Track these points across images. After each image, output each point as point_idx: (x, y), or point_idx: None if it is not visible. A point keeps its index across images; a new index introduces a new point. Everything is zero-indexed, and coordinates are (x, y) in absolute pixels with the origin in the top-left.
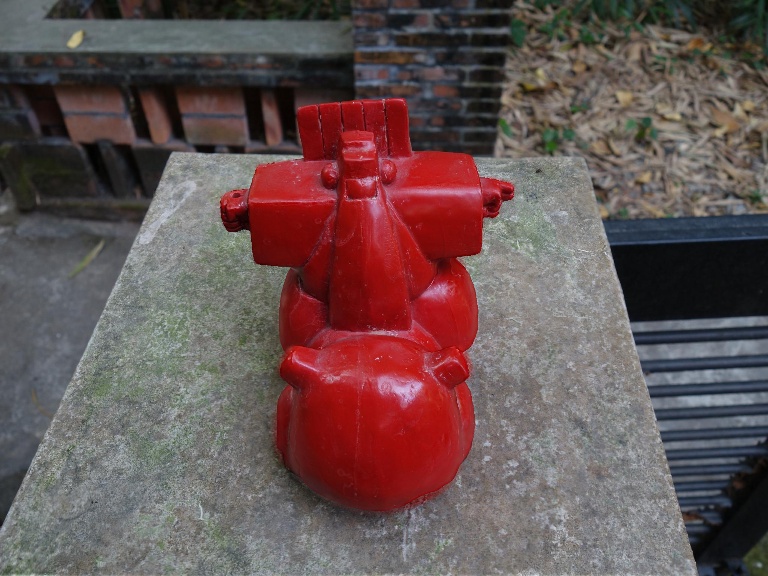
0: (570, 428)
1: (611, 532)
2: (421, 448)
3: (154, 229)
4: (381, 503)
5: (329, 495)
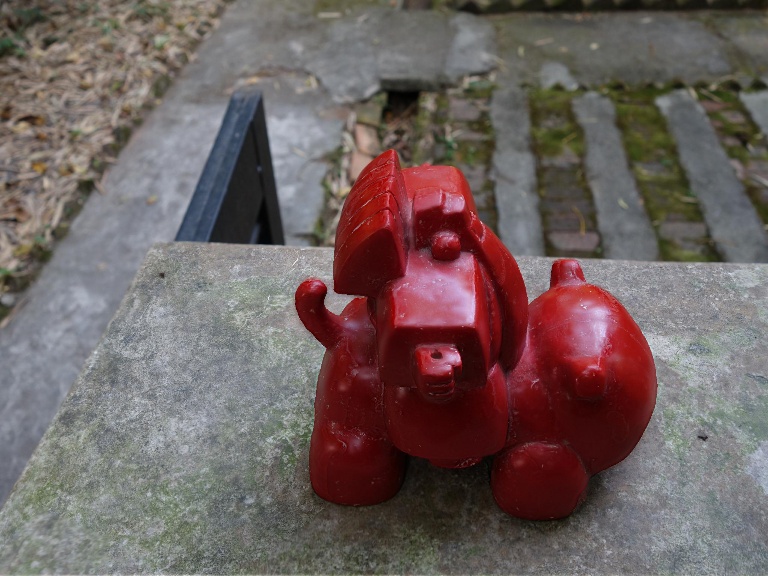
0: None
1: None
2: None
3: None
4: None
5: None
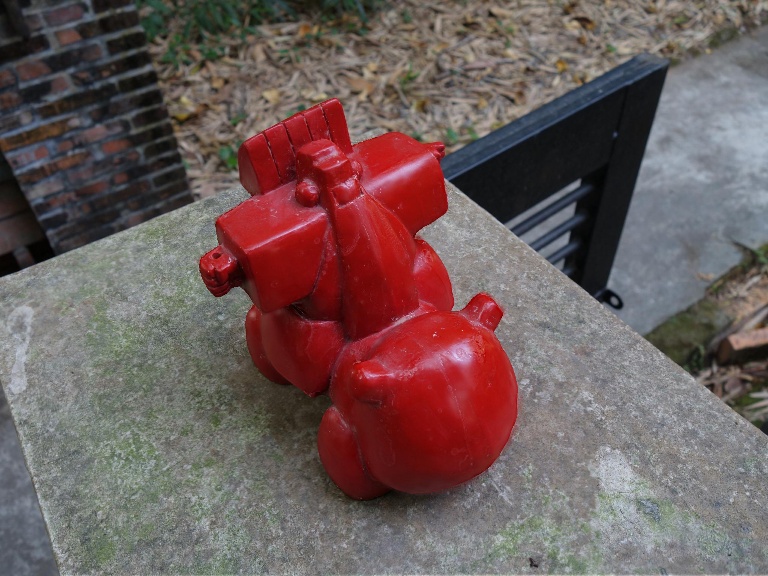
0: (541, 332)
1: (626, 387)
2: (505, 391)
3: (20, 372)
4: (489, 461)
5: (442, 483)
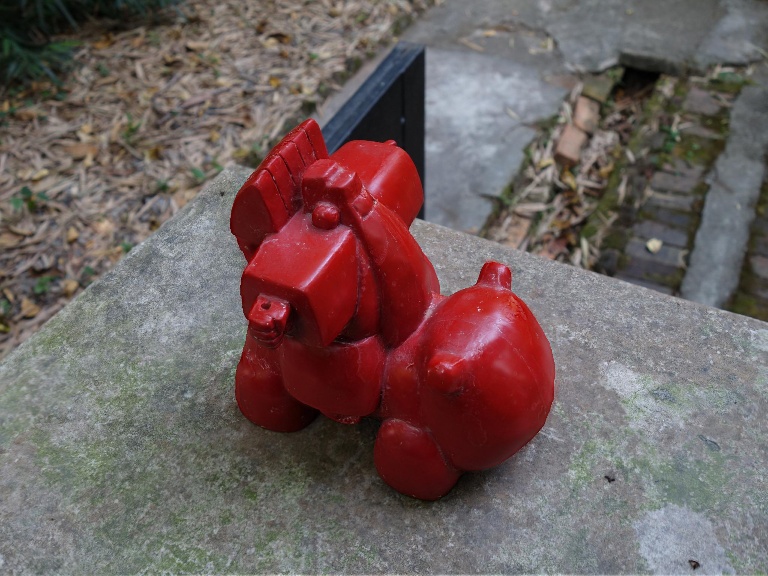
0: None
1: (586, 310)
2: (545, 338)
3: None
4: None
5: (524, 442)
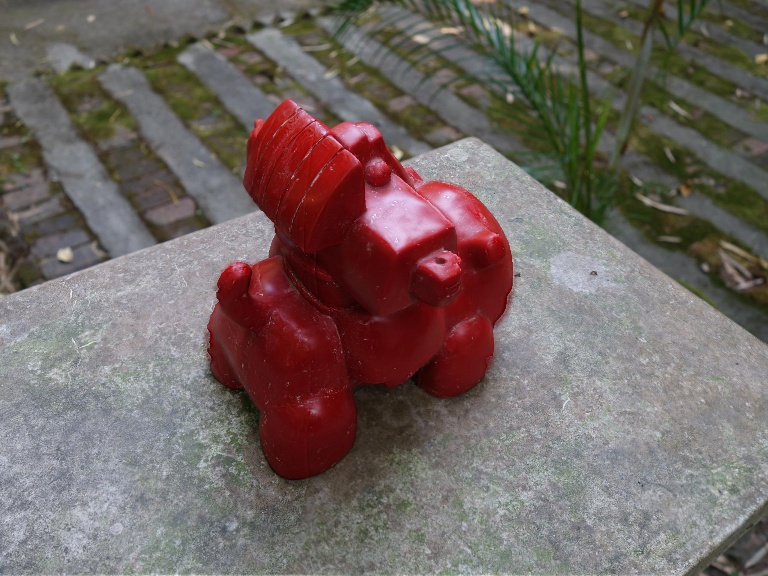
0: None
1: None
2: None
3: None
4: None
5: None
